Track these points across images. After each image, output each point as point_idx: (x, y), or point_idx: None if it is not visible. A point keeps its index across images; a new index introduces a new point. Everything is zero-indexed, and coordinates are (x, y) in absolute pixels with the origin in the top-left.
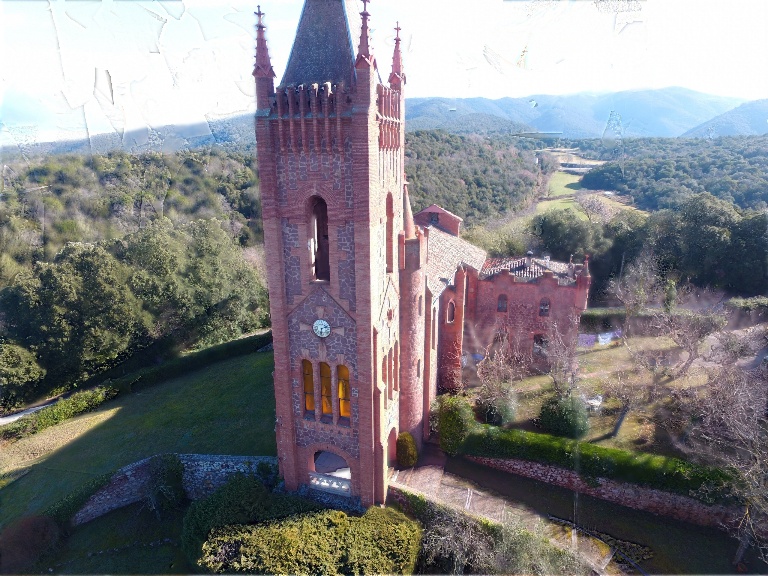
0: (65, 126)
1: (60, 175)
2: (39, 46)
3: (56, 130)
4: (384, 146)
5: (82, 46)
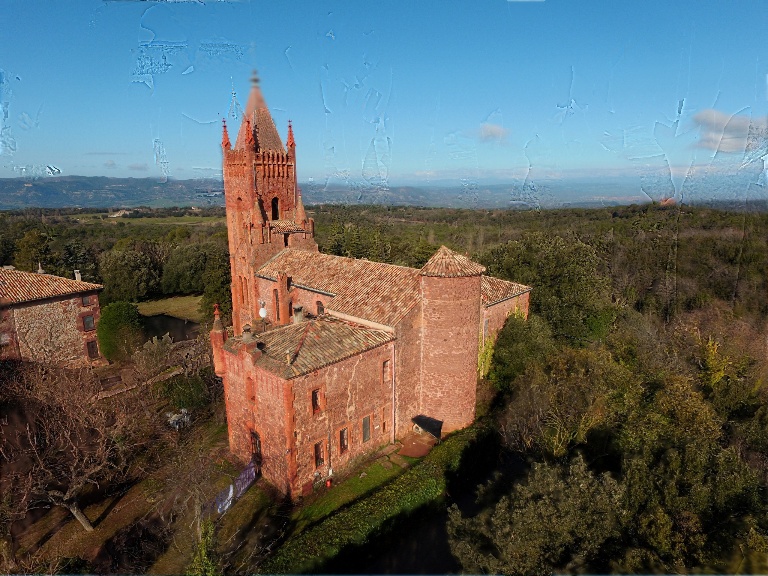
0: (738, 150)
1: (710, 199)
2: (660, 86)
3: (720, 155)
4: (233, 176)
5: (716, 69)
